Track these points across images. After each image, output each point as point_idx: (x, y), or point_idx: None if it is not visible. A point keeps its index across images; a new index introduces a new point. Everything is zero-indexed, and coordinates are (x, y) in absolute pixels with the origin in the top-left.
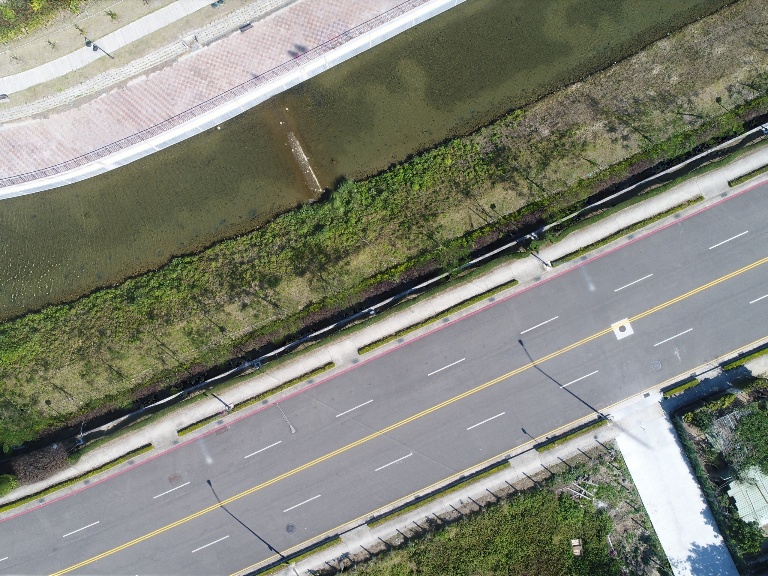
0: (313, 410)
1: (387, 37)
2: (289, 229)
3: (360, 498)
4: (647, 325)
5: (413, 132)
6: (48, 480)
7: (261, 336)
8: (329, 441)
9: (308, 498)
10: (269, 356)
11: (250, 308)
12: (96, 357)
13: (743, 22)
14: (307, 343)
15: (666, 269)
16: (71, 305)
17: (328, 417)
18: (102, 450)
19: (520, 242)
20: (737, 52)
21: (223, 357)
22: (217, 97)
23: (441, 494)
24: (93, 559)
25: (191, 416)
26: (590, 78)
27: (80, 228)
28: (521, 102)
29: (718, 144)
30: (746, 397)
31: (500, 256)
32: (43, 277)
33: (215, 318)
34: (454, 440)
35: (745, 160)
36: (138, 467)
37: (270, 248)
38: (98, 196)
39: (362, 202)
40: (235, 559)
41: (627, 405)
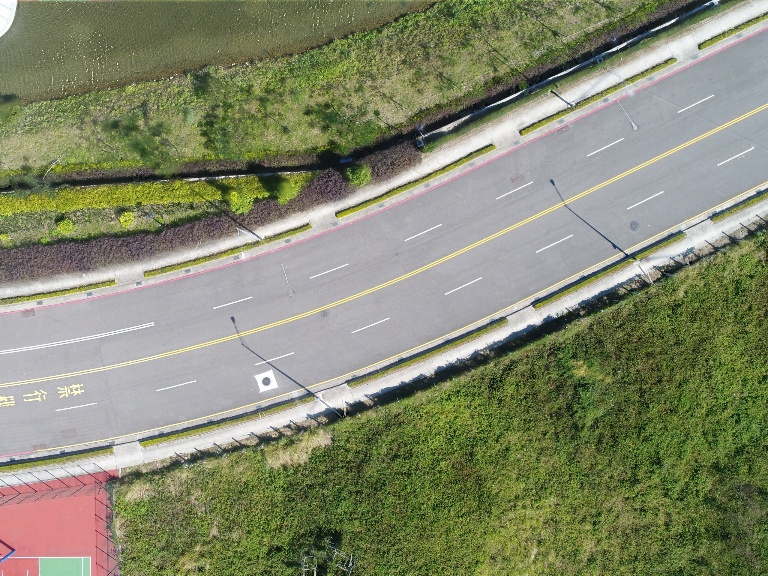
0: (654, 107)
1: None
2: None
3: (703, 194)
4: None
5: None
6: (388, 184)
7: (597, 36)
8: (671, 137)
9: (651, 195)
10: (611, 52)
11: (583, 11)
12: (426, 65)
13: None
14: (648, 39)
15: None
16: (379, 29)
17: (670, 113)
18: (443, 152)
19: None
20: None
21: (559, 59)
22: None
23: None
24: (436, 262)
25: (532, 115)
26: None
27: None
28: None
29: None
30: None
31: None
32: (344, 6)
33: (547, 22)
34: None
35: None
36: (479, 169)
37: None
38: None
39: None
40: (579, 258)
41: None
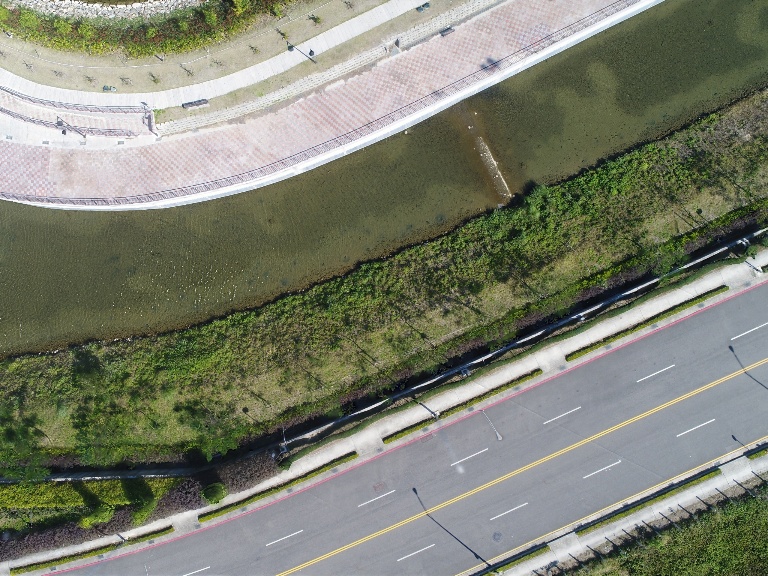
0: (520, 417)
1: (579, 41)
2: (483, 234)
3: (568, 506)
4: None
5: (603, 136)
6: (251, 488)
7: (465, 343)
8: (536, 448)
9: (515, 506)
10: (476, 363)
11: (452, 314)
12: (295, 364)
13: None
14: (514, 350)
15: None
16: (257, 311)
17: (535, 424)
18: (306, 458)
19: (731, 247)
20: None
21: (426, 364)
22: (417, 102)
23: (651, 502)
24: (297, 568)
25: (396, 423)
26: None
27: (264, 234)
28: (713, 106)
29: None
30: None
31: (712, 262)
32: (226, 283)
33: (416, 324)
34: (663, 447)
35: None
36: (342, 475)
37: (464, 254)
38: (282, 201)
39: (558, 207)
40: (441, 568)
41: None
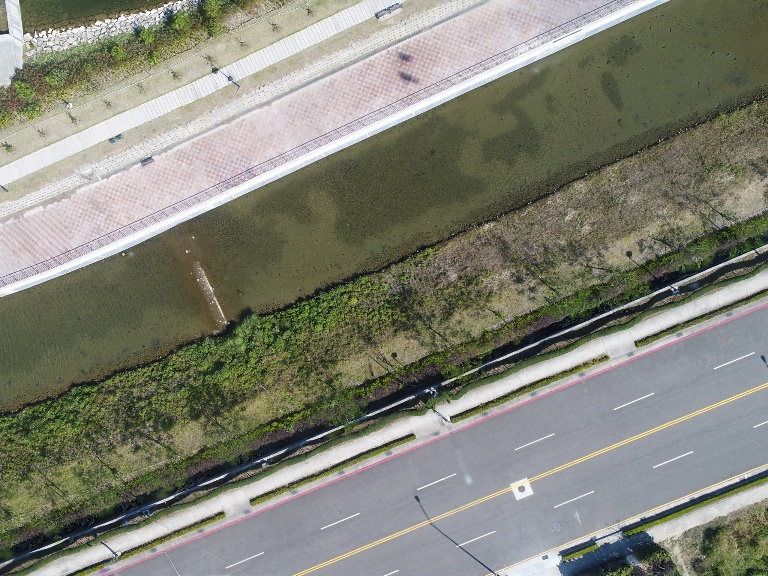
0: (202, 560)
1: (297, 168)
2: (190, 364)
3: None
4: (547, 486)
5: (322, 265)
6: None
7: (152, 481)
8: None
9: None
10: (158, 504)
11: (143, 450)
12: None
13: (661, 169)
14: (198, 492)
15: (568, 429)
16: None
17: (217, 568)
18: None
19: (419, 396)
20: (651, 203)
21: (113, 501)
22: (115, 231)
23: None
24: None
25: (77, 562)
26: (504, 218)
27: None
28: (433, 239)
29: (625, 303)
30: (646, 565)
31: (397, 410)
32: None
33: (107, 459)
34: None
35: (653, 320)
36: None
37: (169, 384)
38: None
39: (264, 340)
40: None
41: (525, 567)
